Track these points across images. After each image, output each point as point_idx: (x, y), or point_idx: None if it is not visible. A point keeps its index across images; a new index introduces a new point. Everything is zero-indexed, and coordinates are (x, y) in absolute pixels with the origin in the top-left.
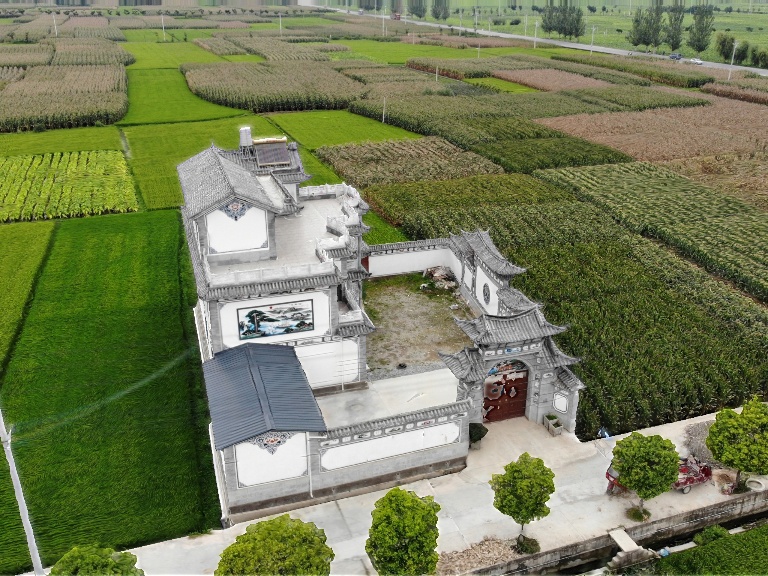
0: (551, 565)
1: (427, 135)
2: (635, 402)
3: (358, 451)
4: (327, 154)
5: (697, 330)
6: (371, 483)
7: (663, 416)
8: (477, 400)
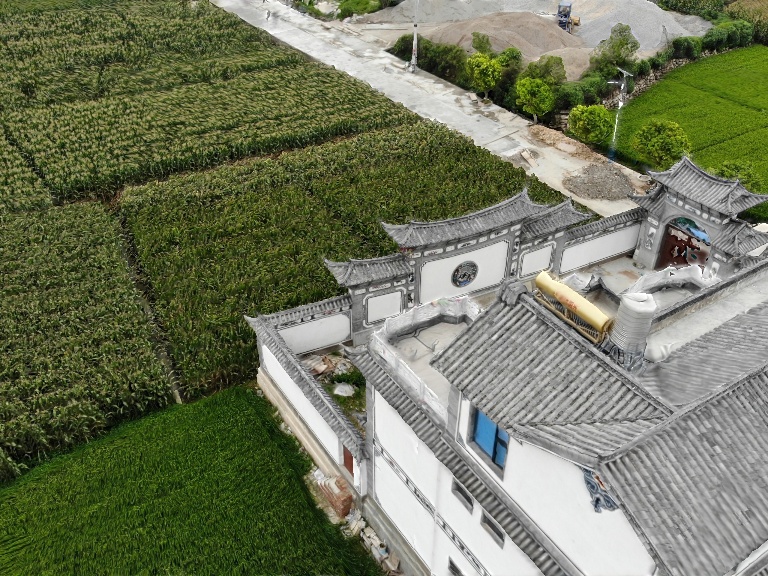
0: None
1: None
2: None
3: None
4: None
5: None
6: None
7: None
8: None
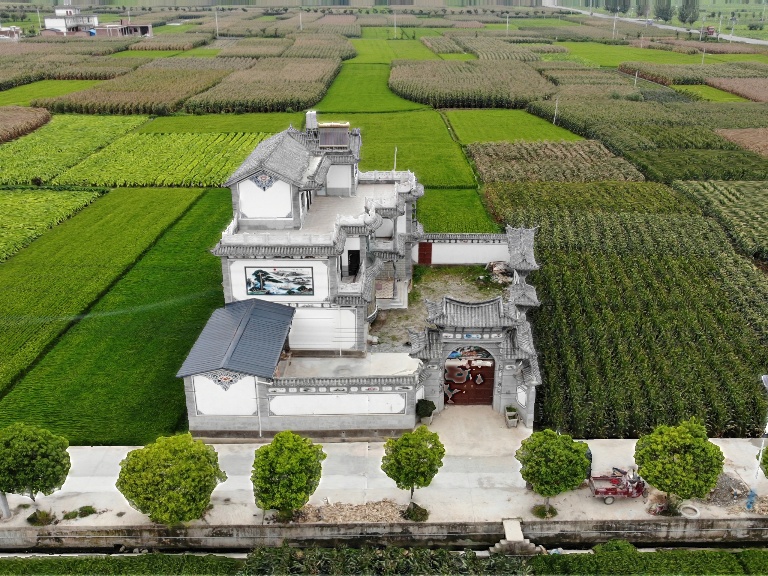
0: (438, 538)
1: (589, 139)
2: (614, 412)
3: (304, 403)
4: (474, 150)
5: (734, 355)
6: (317, 435)
7: (644, 432)
8: (434, 379)
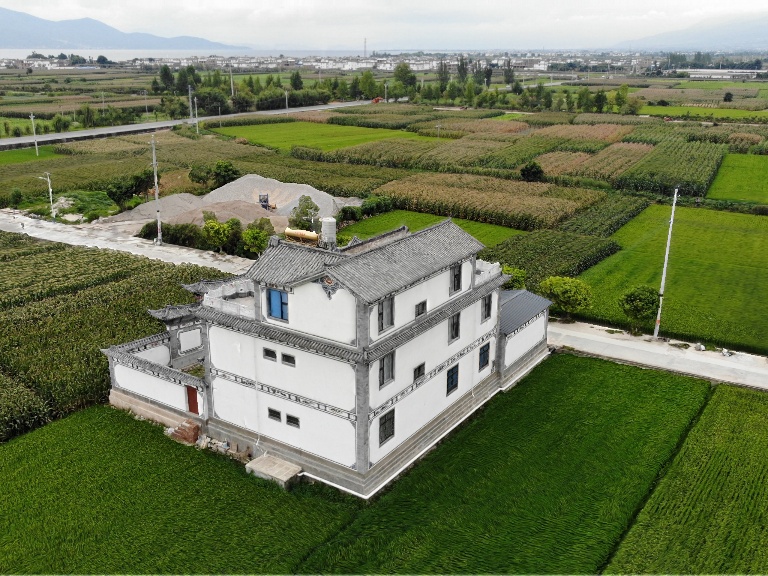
0: None
1: None
2: None
3: None
4: None
5: None
6: None
7: None
8: None
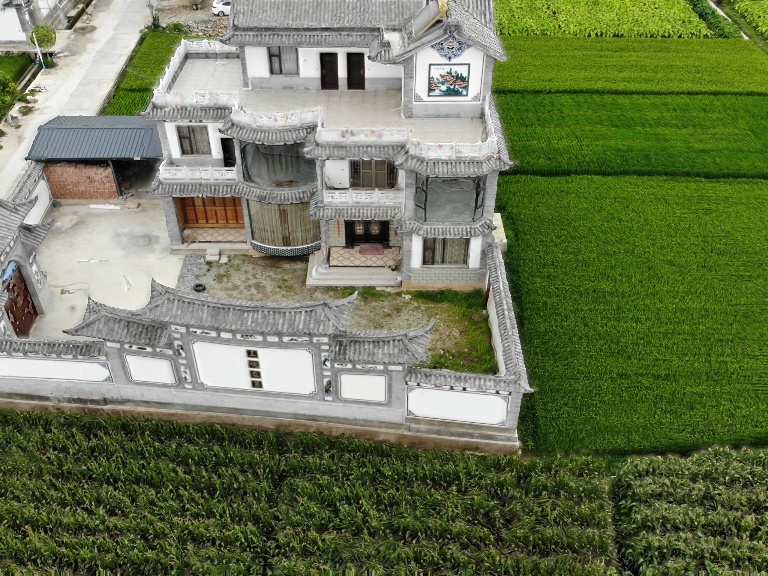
0: None
1: None
2: None
3: None
4: None
5: None
6: None
7: None
8: None
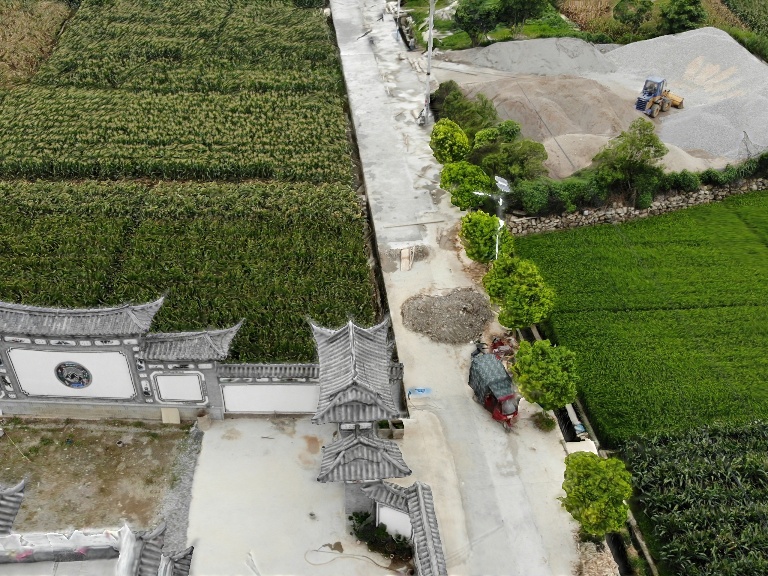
0: None
1: None
2: None
3: None
4: None
5: None
6: None
7: None
8: None
